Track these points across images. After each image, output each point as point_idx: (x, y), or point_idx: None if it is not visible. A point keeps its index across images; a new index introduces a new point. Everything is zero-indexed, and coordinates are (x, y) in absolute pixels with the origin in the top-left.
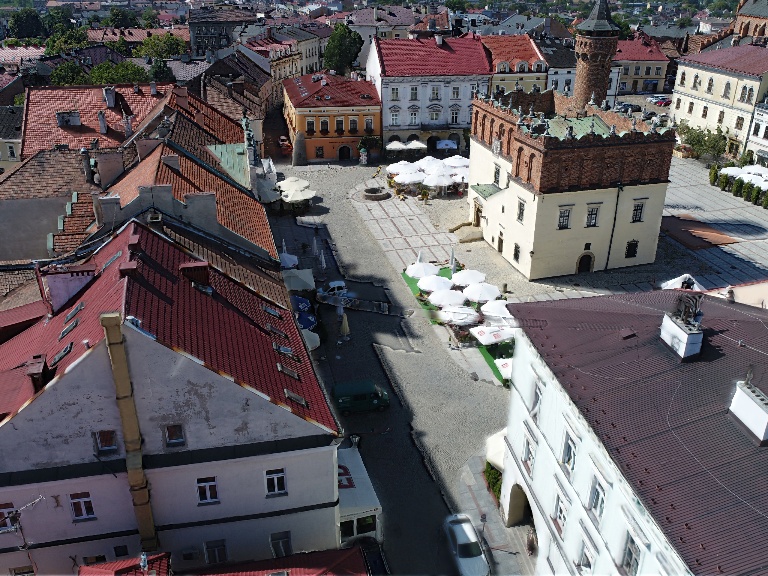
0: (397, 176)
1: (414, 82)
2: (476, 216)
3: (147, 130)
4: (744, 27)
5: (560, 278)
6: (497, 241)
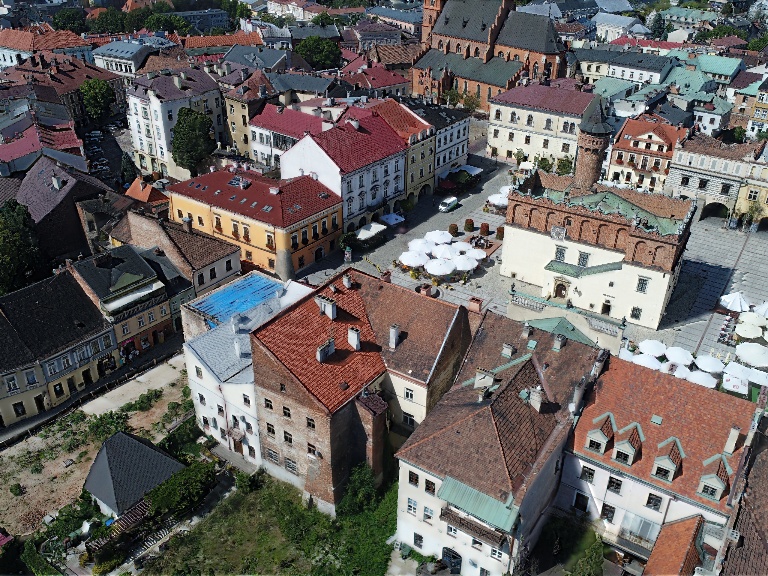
0: (432, 270)
1: (362, 171)
2: (556, 290)
3: (449, 335)
4: (447, 45)
5: (663, 320)
6: (600, 307)
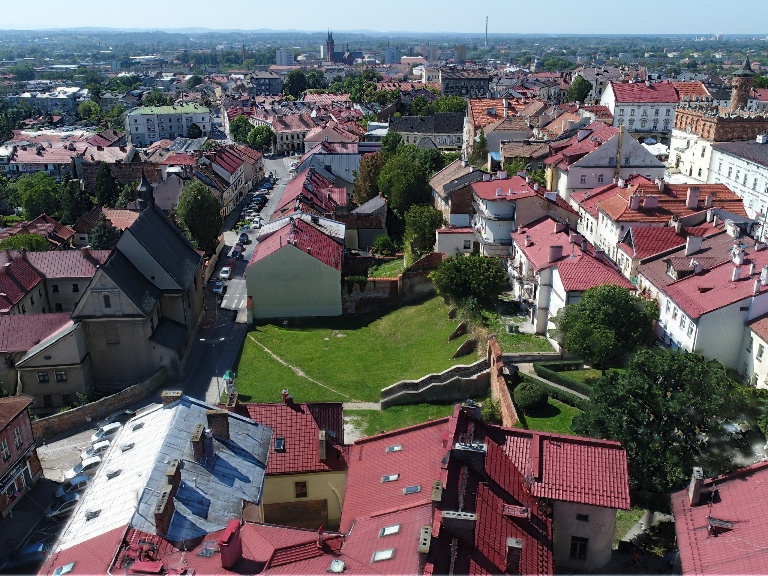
0: None
1: (633, 106)
2: (677, 163)
3: (535, 114)
4: None
5: None
6: (689, 171)
